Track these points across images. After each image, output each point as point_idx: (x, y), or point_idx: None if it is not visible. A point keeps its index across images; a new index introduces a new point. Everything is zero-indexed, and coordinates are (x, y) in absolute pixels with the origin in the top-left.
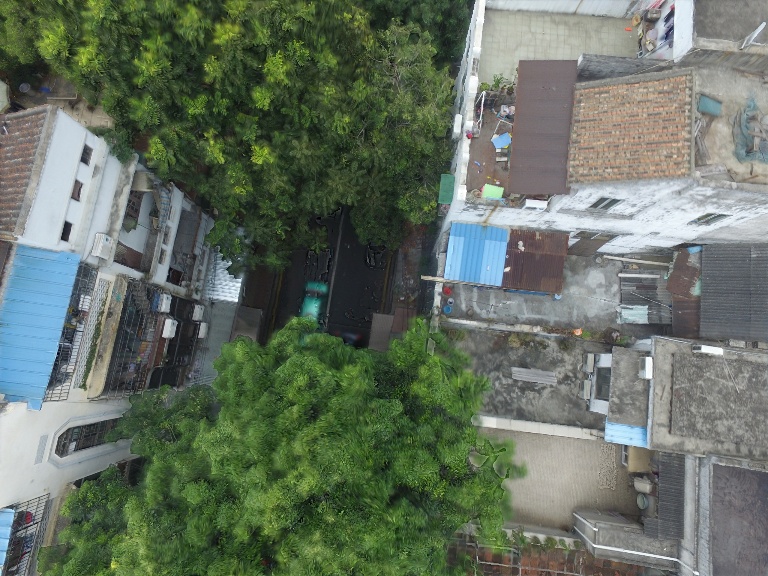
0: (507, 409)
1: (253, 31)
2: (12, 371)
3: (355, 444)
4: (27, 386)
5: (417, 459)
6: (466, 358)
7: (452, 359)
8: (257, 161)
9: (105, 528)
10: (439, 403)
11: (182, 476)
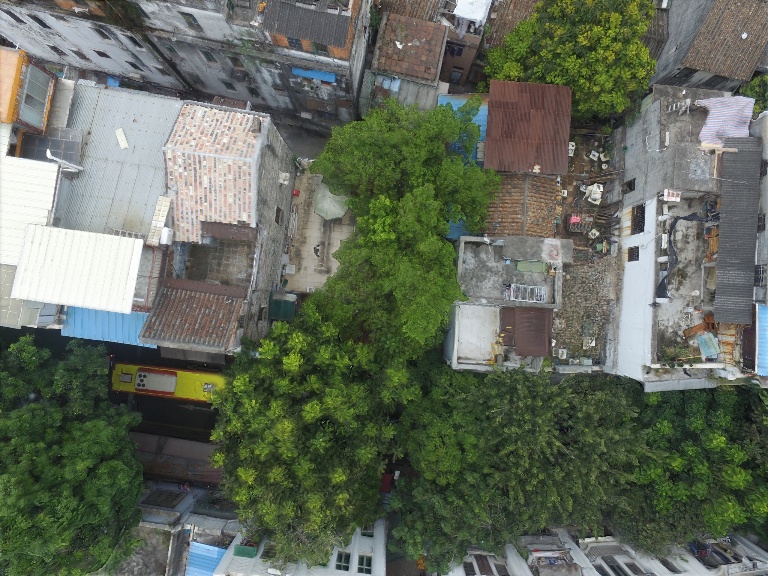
0: (117, 570)
1: (267, 482)
2: (81, 319)
3: (5, 557)
4: (73, 328)
5: (16, 573)
6: (152, 543)
7: (151, 533)
8: (215, 458)
9: None
10: (59, 575)
11: (3, 448)
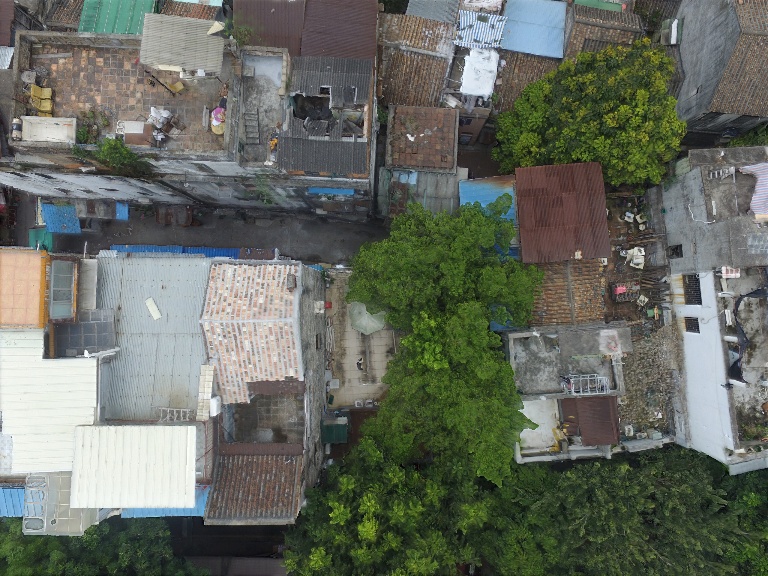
0: None
1: None
2: None
3: None
4: (133, 509)
5: None
6: None
7: None
8: None
9: (64, 569)
10: None
11: None
